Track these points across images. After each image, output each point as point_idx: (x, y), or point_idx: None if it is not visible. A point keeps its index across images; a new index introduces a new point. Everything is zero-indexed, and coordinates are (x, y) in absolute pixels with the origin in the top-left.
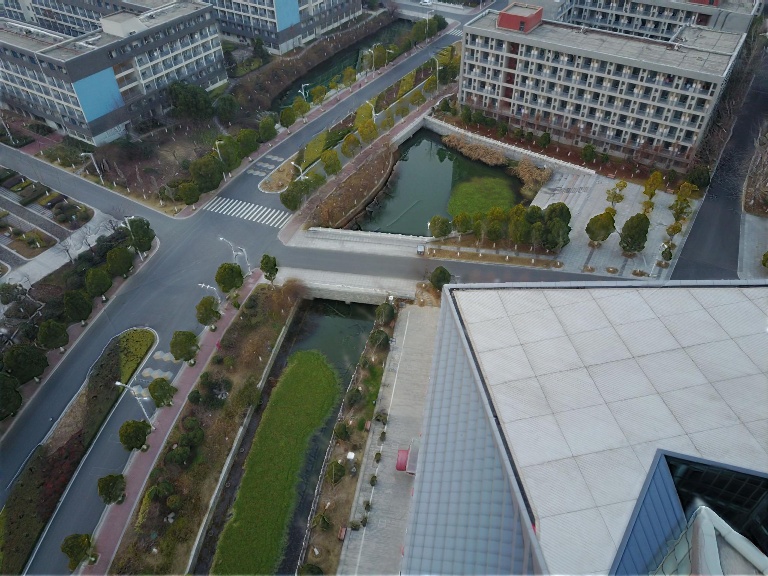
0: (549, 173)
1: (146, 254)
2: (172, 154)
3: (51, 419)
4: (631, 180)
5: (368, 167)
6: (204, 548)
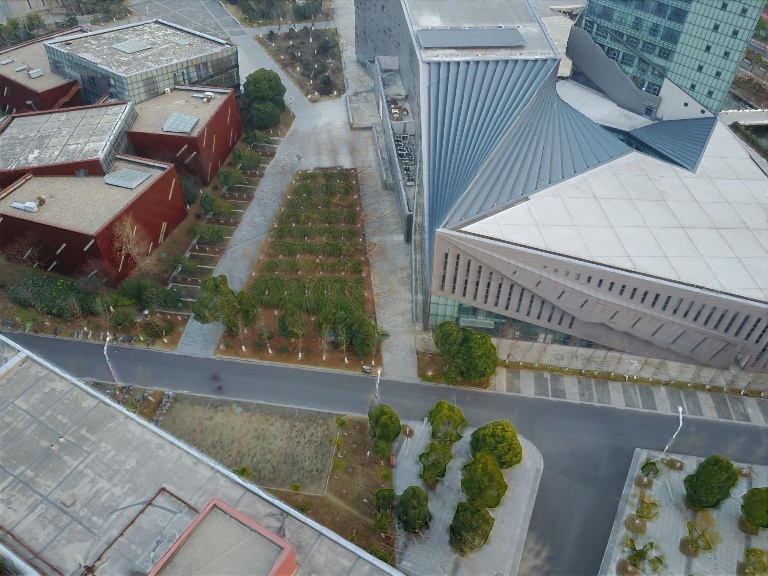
0: None
1: None
2: None
3: None
4: None
5: None
6: None
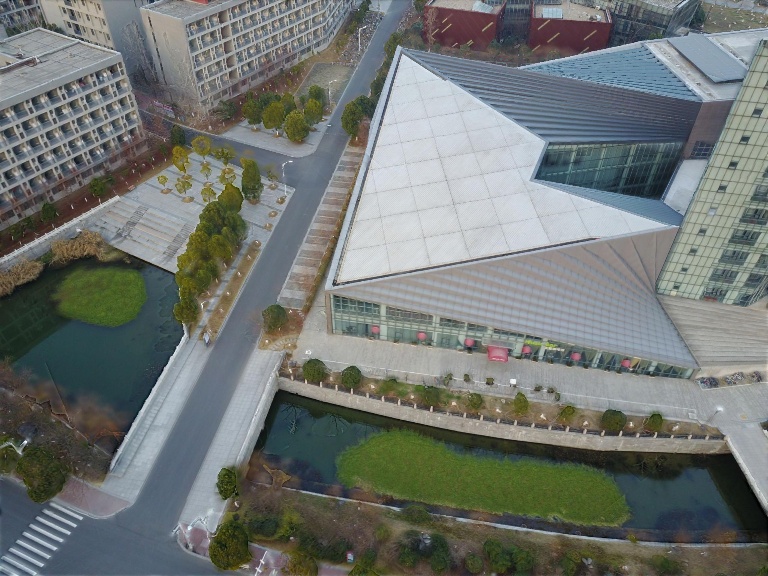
0: (89, 232)
1: None
2: None
3: None
4: (144, 178)
5: None
6: None
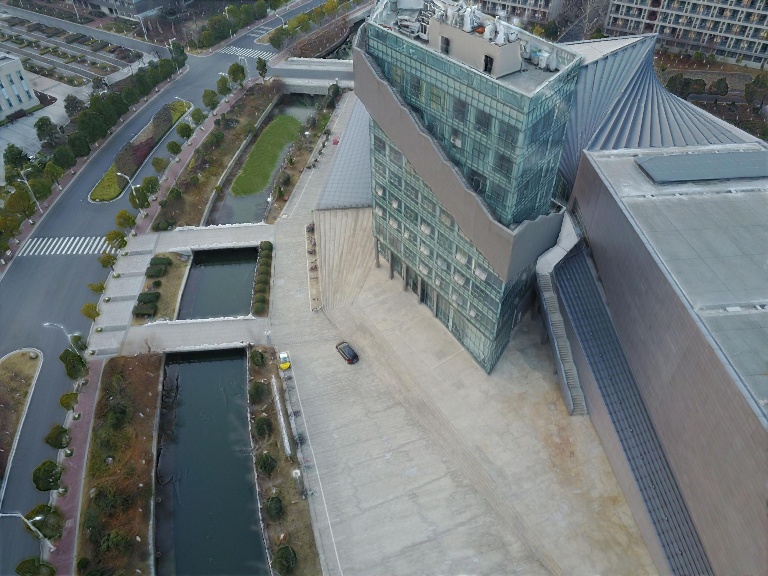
0: None
1: (181, 71)
2: (194, 25)
3: (133, 134)
4: None
5: (331, 31)
6: (226, 182)
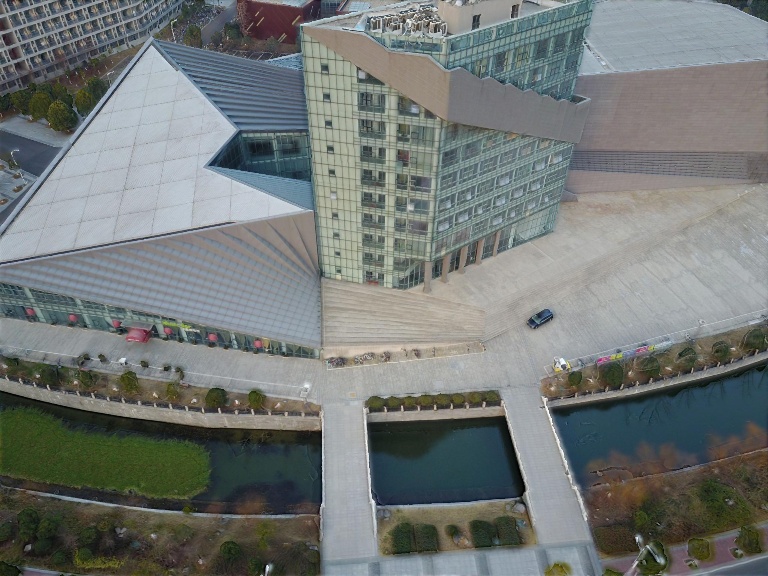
0: None
1: None
2: None
3: None
4: None
5: None
6: None
